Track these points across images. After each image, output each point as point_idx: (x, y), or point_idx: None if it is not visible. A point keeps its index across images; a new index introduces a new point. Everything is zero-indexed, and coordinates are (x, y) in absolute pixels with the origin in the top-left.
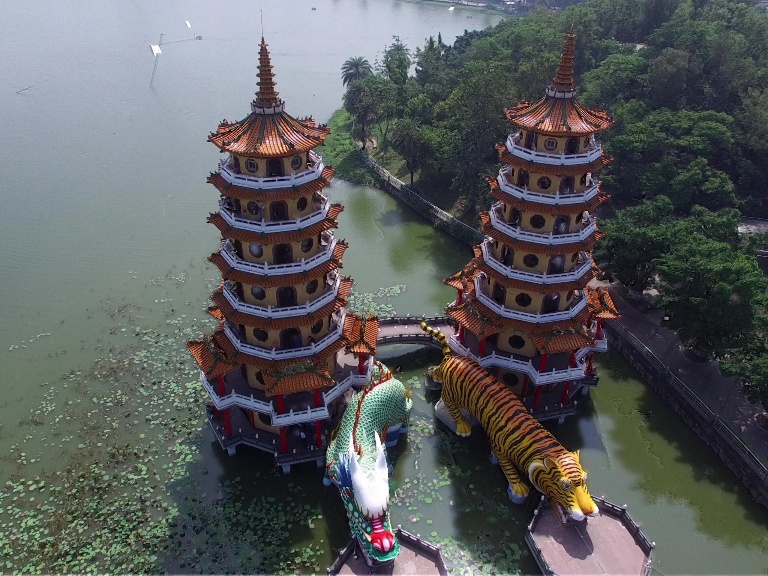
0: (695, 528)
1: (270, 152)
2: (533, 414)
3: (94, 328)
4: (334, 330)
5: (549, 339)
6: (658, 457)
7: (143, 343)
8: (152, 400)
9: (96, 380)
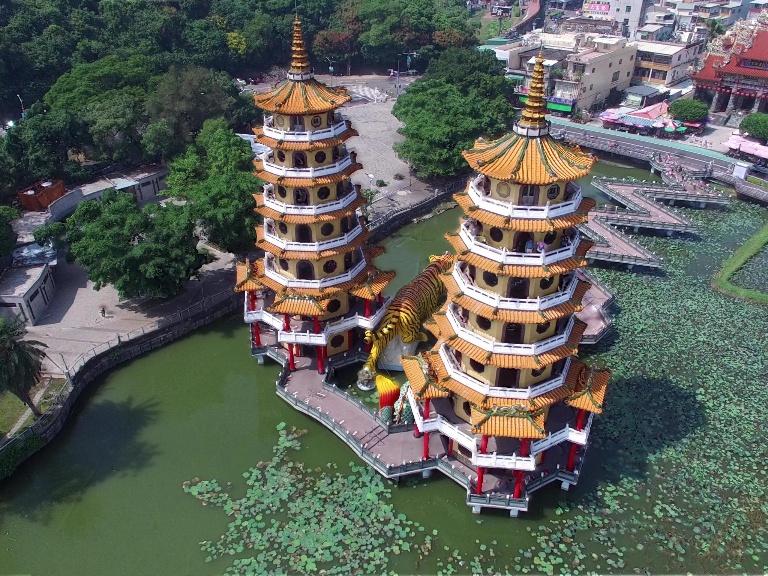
0: None
1: None
2: None
3: None
4: None
5: (374, 246)
6: None
7: None
8: None
9: None
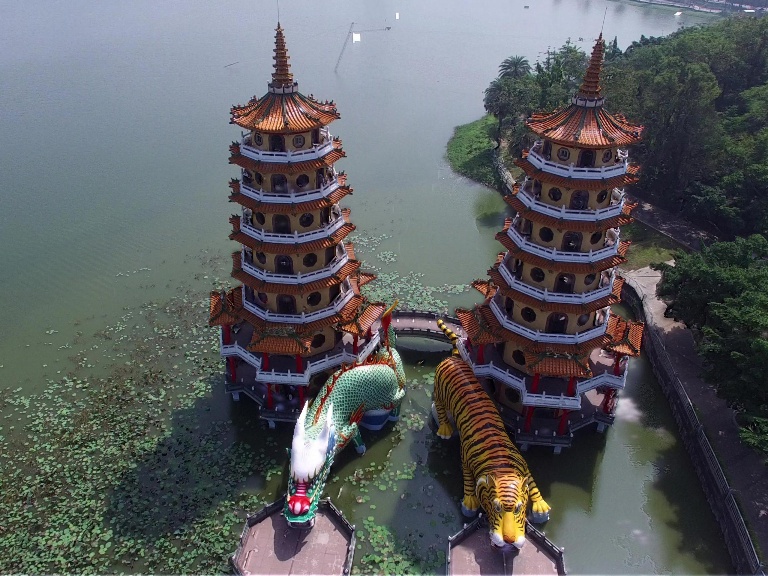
0: None
1: (267, 128)
2: (521, 435)
3: (184, 271)
4: (330, 306)
5: (539, 359)
6: (649, 516)
7: None
8: (198, 340)
9: (165, 314)
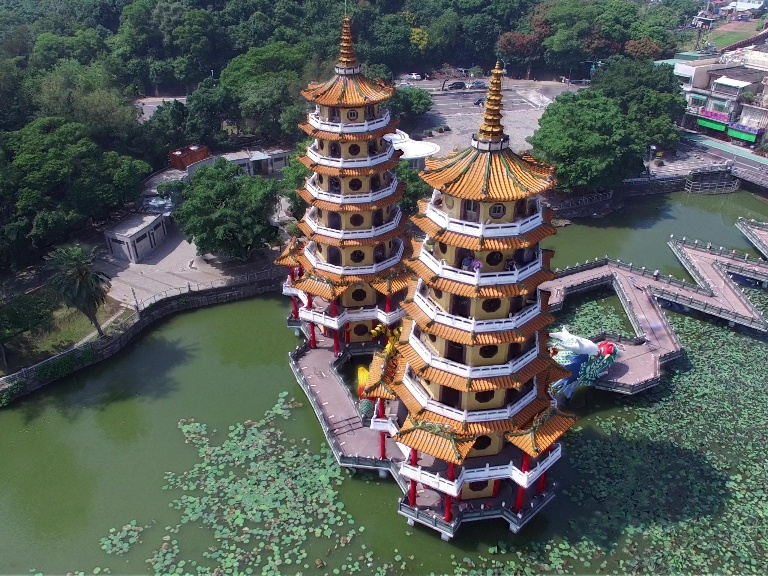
0: None
1: None
2: None
3: None
4: None
5: None
6: None
7: None
8: None
9: None
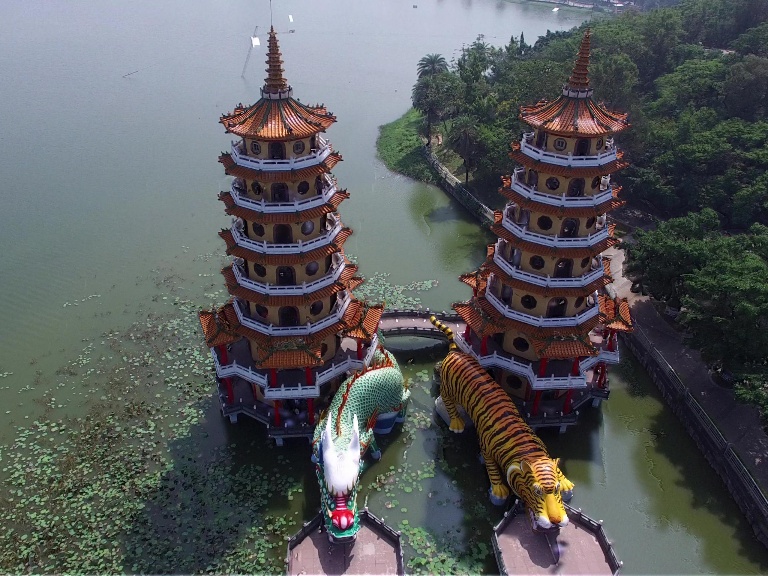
0: (689, 558)
1: (269, 135)
2: (530, 419)
3: (139, 294)
4: (333, 313)
5: (548, 344)
6: (659, 479)
7: (179, 312)
8: (174, 364)
9: (130, 341)
